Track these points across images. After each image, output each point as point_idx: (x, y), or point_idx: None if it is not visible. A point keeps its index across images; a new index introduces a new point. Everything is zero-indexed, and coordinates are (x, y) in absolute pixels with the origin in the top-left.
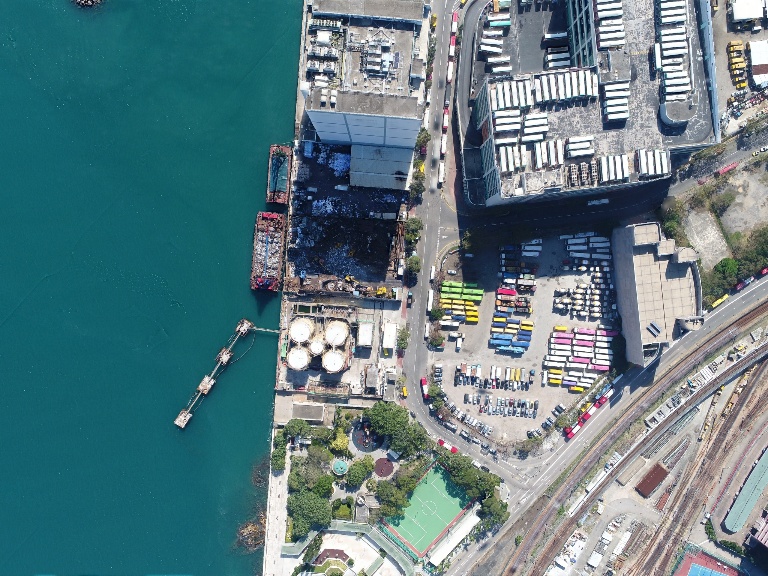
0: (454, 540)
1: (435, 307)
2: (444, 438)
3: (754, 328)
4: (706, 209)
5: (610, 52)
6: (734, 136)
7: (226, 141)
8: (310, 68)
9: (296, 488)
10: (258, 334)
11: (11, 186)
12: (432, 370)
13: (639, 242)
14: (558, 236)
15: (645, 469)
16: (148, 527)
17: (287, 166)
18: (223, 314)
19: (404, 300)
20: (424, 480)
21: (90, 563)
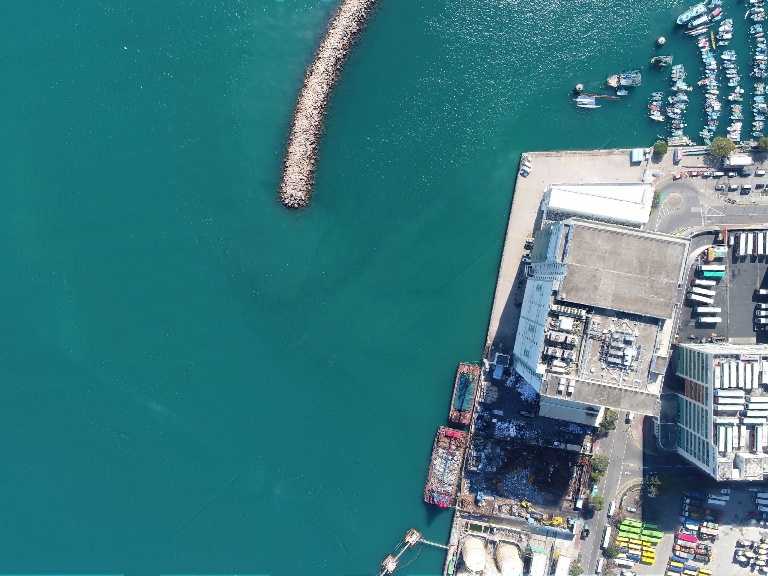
0: None
1: (612, 546)
2: None
3: None
4: None
5: None
6: None
7: (414, 352)
8: (550, 354)
9: None
10: (425, 545)
11: (210, 390)
12: None
13: None
14: None
15: None
16: None
17: (474, 385)
18: (393, 522)
19: None
20: None
21: None
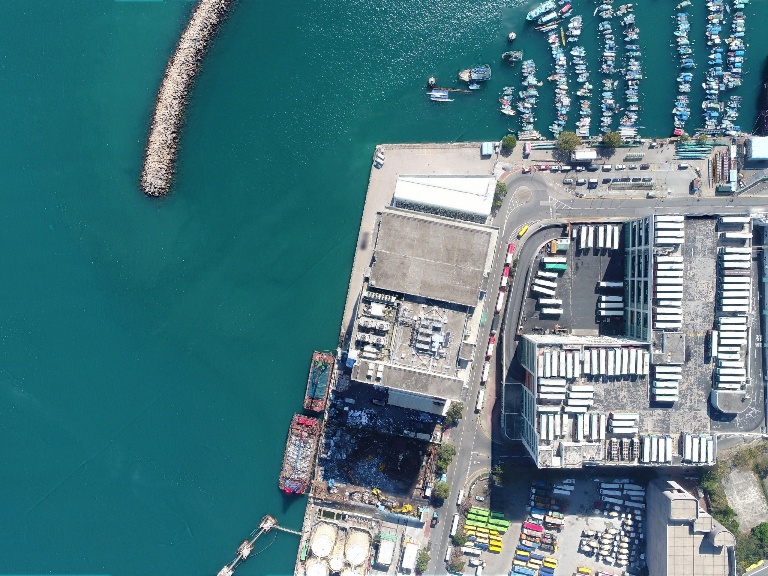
0: None
1: (459, 534)
2: None
3: None
4: (749, 468)
5: (665, 334)
6: None
7: (271, 340)
8: (360, 340)
9: None
10: (280, 531)
11: (61, 374)
12: None
13: (675, 516)
14: None
15: None
16: None
17: (328, 374)
18: (249, 508)
19: (429, 519)
20: None
21: None
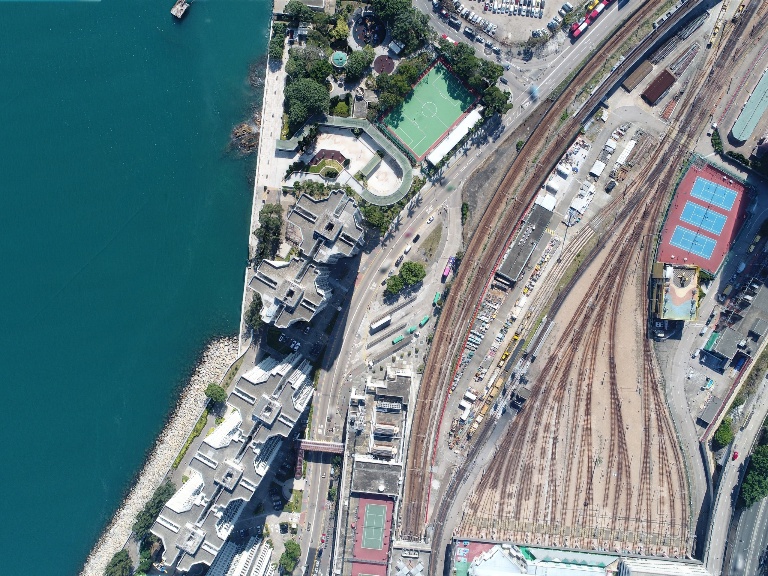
0: (454, 137)
1: None
2: None
3: None
4: None
5: None
6: None
7: None
8: None
9: (293, 71)
10: None
11: None
12: None
13: None
14: None
15: (652, 76)
16: (140, 90)
17: None
18: None
19: None
20: (425, 80)
21: (78, 128)
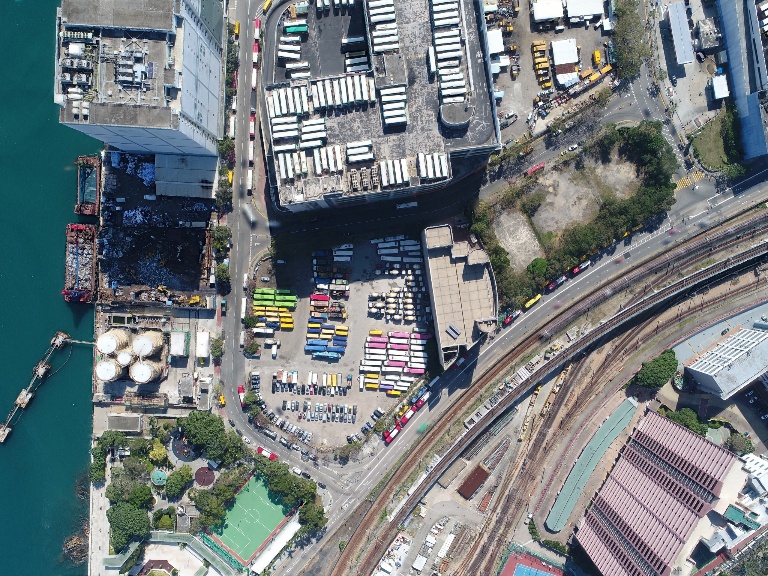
0: (275, 547)
1: (247, 315)
2: (264, 445)
3: (570, 327)
4: (517, 209)
5: (384, 56)
6: (542, 136)
7: (35, 153)
8: (62, 80)
9: (112, 500)
10: (75, 346)
11: None
12: (249, 378)
13: (432, 245)
14: (369, 240)
15: (466, 471)
16: None
17: (95, 177)
18: (38, 327)
19: (219, 308)
20: (246, 488)
21: None
